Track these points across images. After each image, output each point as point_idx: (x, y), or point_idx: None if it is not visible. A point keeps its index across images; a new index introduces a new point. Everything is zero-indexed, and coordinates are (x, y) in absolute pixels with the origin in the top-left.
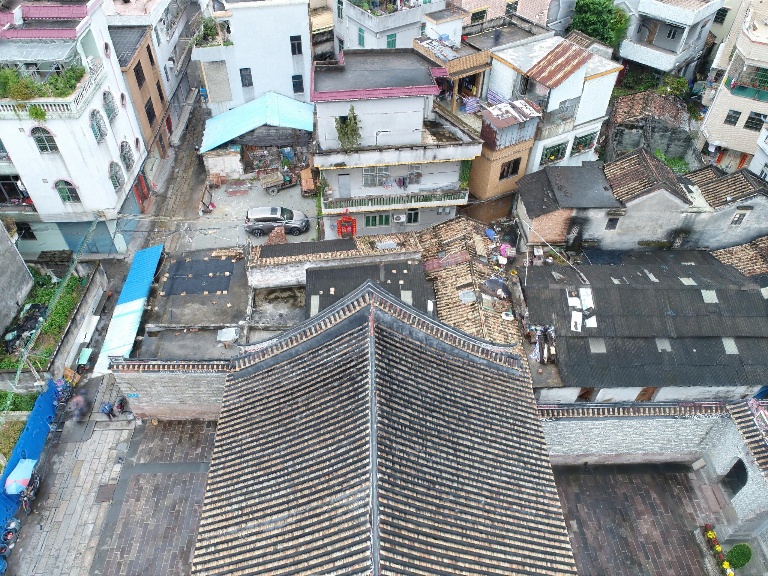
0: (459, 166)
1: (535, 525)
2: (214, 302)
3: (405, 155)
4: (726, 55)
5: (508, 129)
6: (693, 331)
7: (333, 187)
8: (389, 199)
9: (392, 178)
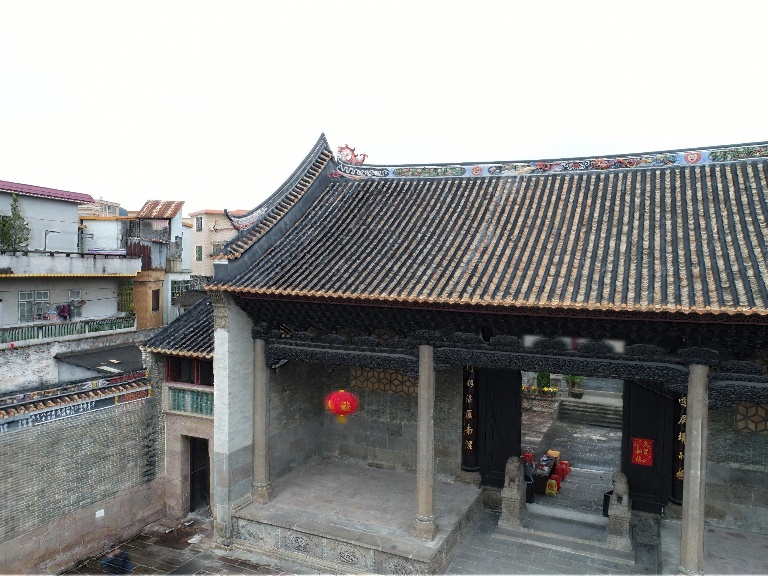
0: (116, 293)
1: None
2: None
3: (76, 264)
4: (208, 266)
5: (155, 247)
6: None
7: None
8: (61, 328)
9: (55, 305)
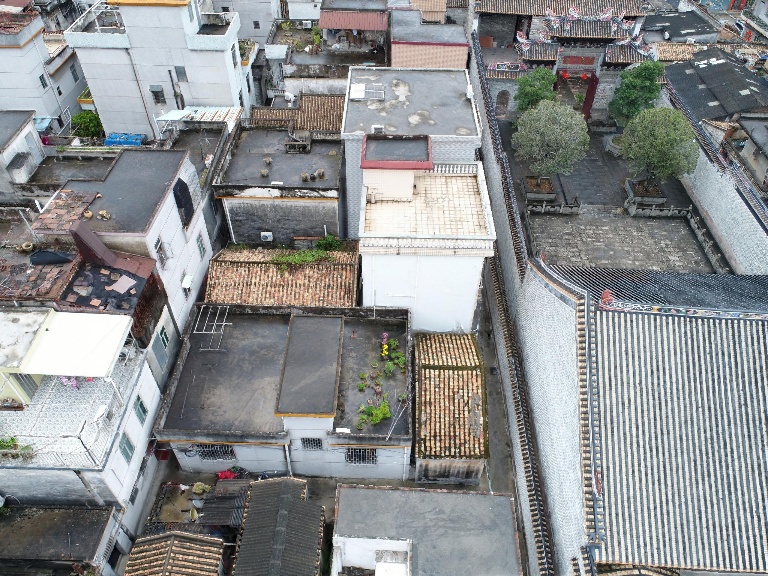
0: None
1: (580, 6)
2: (665, 5)
3: None
4: None
5: None
6: (716, 91)
7: (756, 8)
8: (762, 24)
9: None
